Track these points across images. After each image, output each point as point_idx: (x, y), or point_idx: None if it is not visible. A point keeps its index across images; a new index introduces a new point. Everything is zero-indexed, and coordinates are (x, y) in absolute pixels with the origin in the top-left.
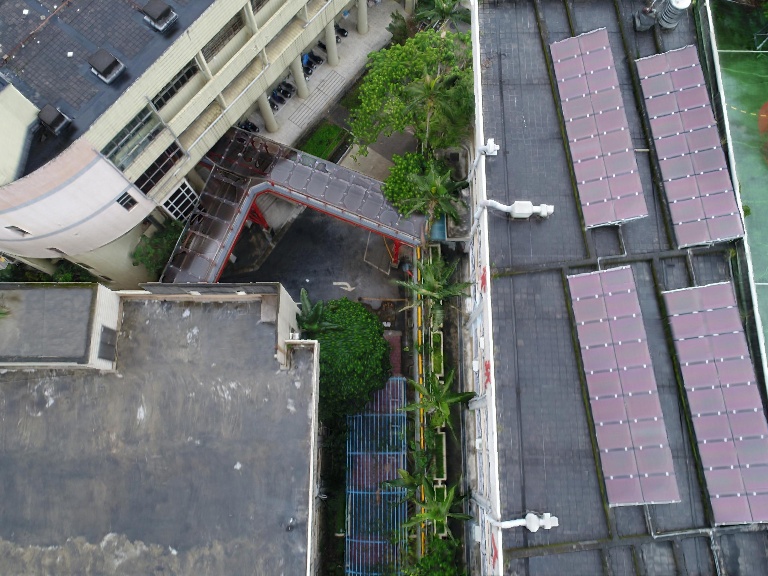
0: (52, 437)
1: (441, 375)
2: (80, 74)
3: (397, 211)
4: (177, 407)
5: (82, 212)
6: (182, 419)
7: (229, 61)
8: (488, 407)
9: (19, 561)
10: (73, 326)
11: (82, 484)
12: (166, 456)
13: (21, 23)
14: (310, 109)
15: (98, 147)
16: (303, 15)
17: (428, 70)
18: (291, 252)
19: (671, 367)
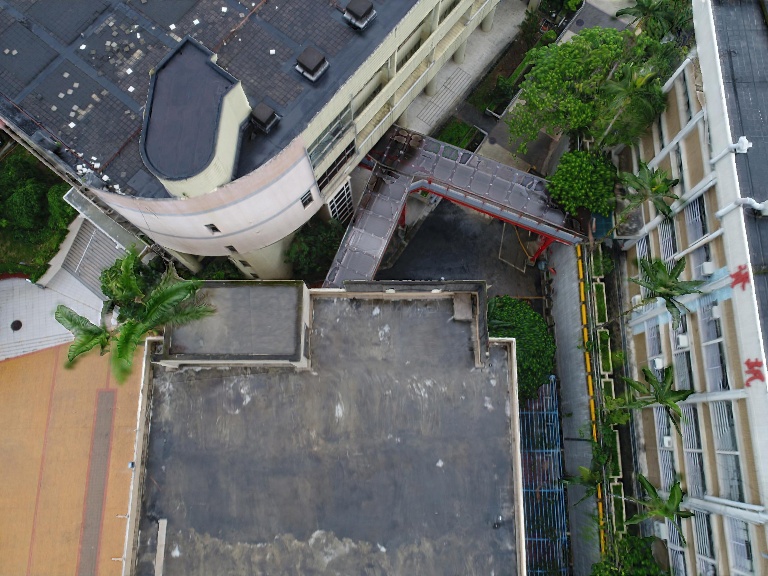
0: (252, 435)
1: (610, 373)
2: (284, 72)
3: (563, 209)
4: (375, 405)
5: (273, 210)
6: (381, 417)
7: (410, 59)
8: (754, 405)
9: (229, 558)
10: (281, 324)
11: (286, 481)
12: (368, 454)
13: (221, 21)
14: (438, 107)
15: (307, 145)
16: (467, 12)
17: (601, 67)
18: (424, 250)
19: None
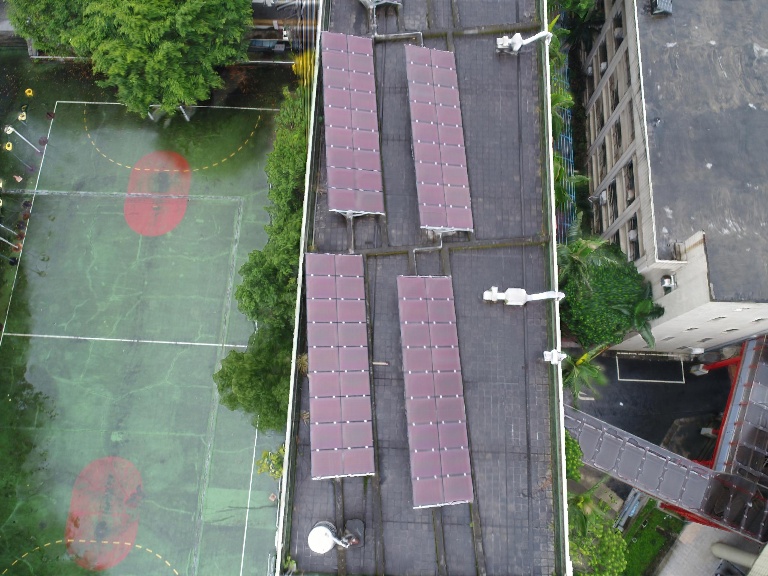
0: None
1: None
2: None
3: None
4: None
5: None
6: (767, 204)
7: None
8: None
9: None
10: None
11: None
12: None
13: None
14: None
15: None
16: None
17: None
18: None
19: (383, 156)
